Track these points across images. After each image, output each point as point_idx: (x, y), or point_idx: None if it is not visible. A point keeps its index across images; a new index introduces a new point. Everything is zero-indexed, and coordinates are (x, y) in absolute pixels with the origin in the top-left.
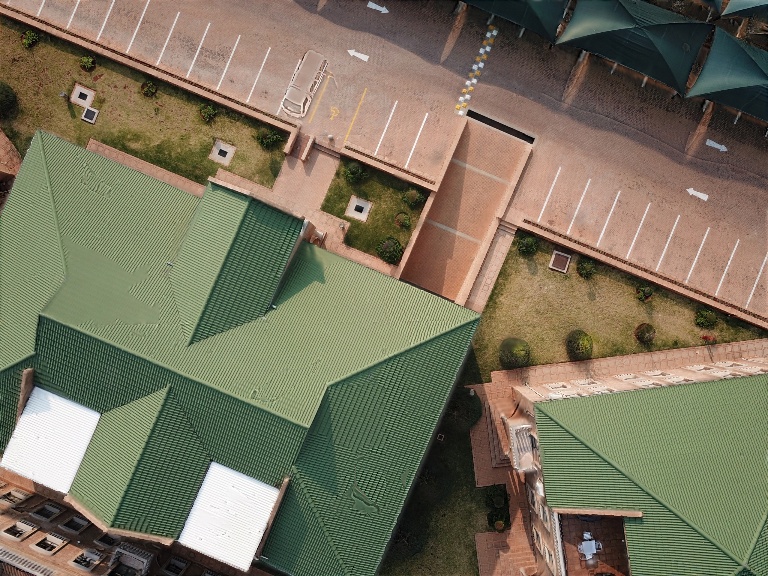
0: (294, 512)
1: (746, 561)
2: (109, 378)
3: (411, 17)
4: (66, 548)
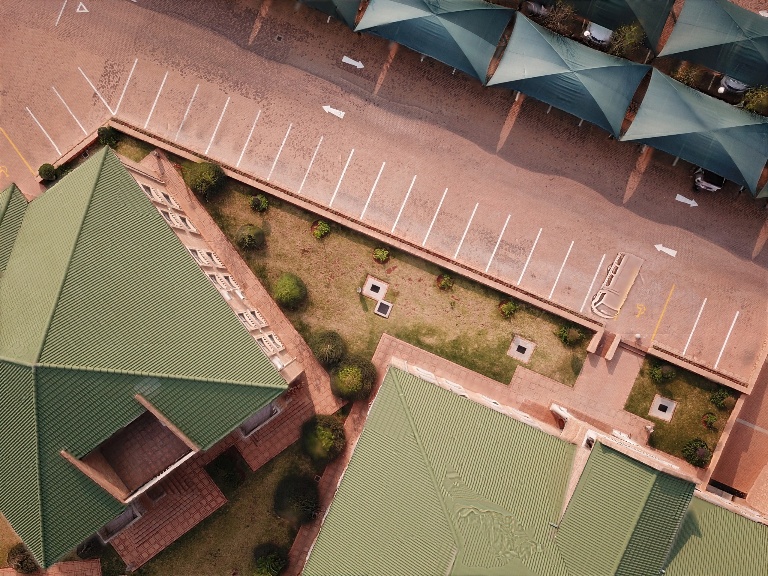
0: None
1: None
2: None
3: (721, 211)
4: None
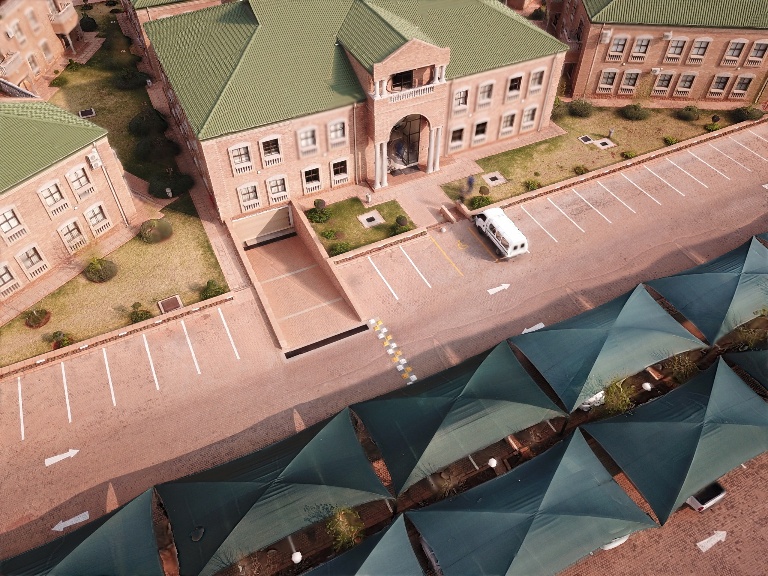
0: None
1: None
2: None
3: None
4: None
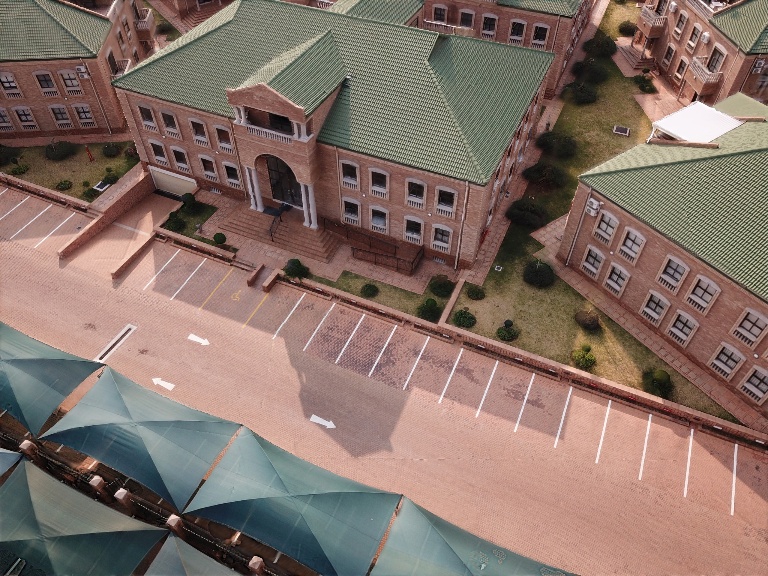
0: None
1: None
2: None
3: None
4: None
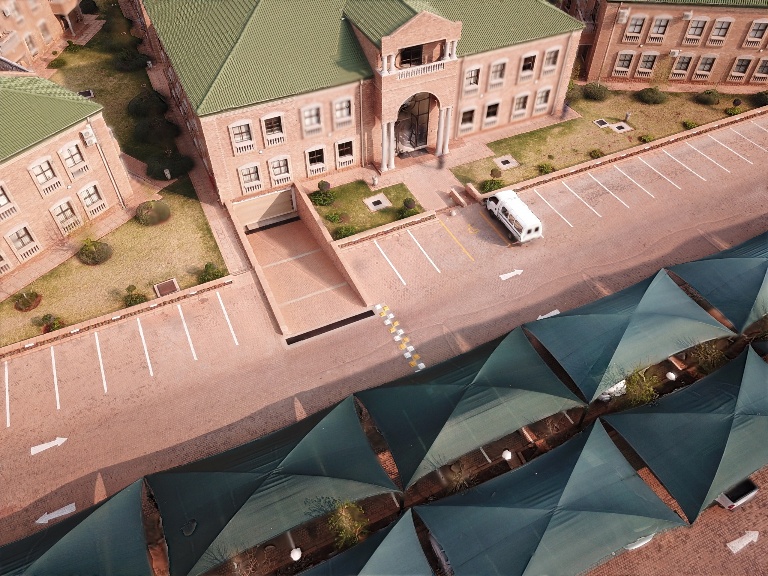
0: None
1: None
2: None
3: None
4: None
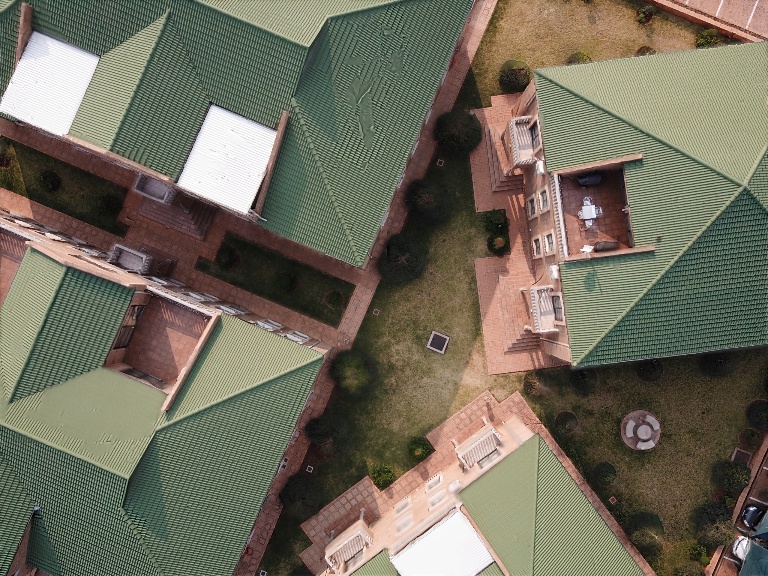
0: (293, 158)
1: (746, 181)
2: (108, 9)
3: None
4: (65, 243)
